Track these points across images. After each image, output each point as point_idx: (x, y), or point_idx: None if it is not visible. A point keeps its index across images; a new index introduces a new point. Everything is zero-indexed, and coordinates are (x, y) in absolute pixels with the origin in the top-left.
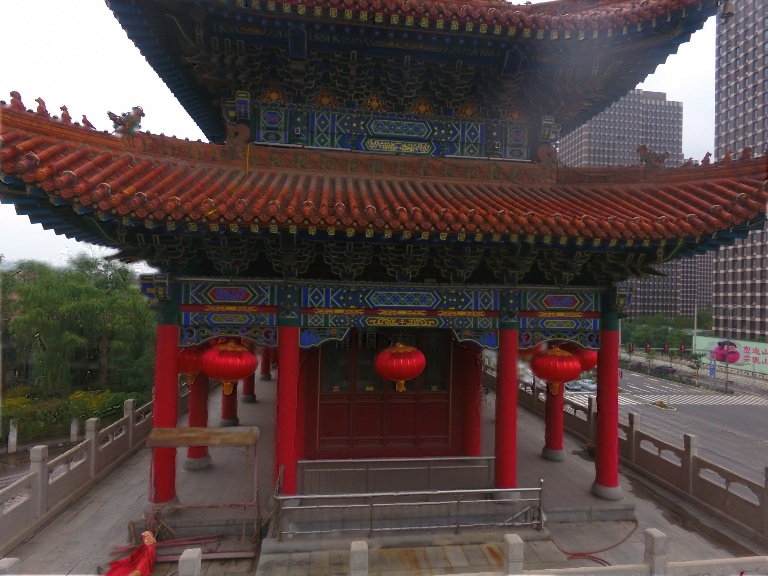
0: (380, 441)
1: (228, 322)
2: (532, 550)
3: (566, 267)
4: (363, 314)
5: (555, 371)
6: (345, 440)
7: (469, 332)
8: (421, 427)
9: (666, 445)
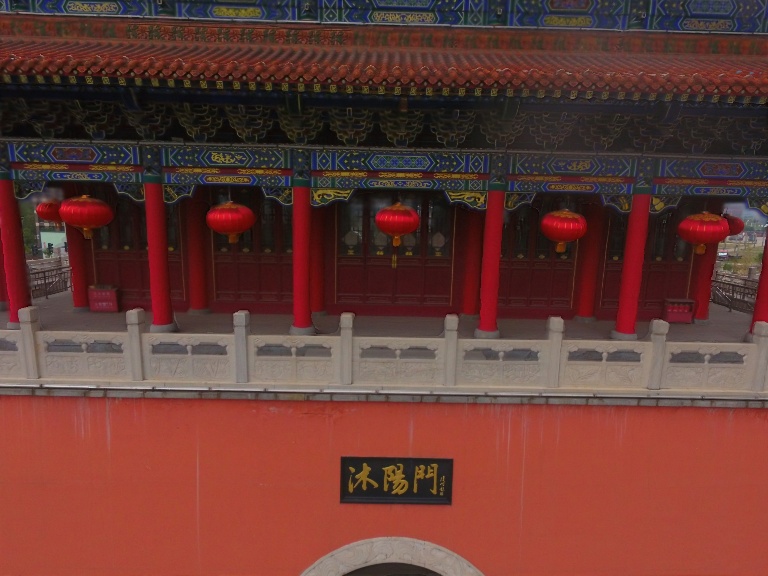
0: None
1: None
2: None
3: None
4: None
5: None
6: None
7: None
8: None
9: None
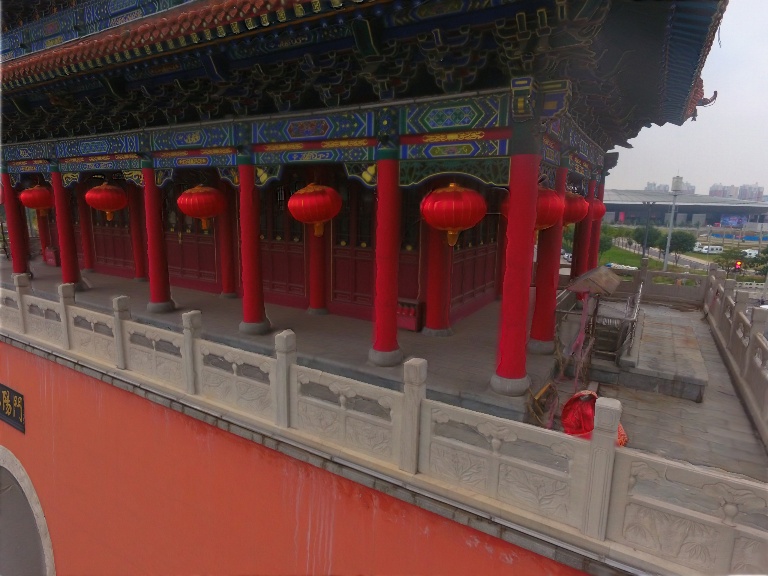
0: (473, 294)
1: (550, 158)
2: (656, 317)
3: (612, 134)
4: (573, 160)
5: (602, 211)
6: (461, 298)
7: (584, 181)
8: (486, 276)
9: (565, 264)
